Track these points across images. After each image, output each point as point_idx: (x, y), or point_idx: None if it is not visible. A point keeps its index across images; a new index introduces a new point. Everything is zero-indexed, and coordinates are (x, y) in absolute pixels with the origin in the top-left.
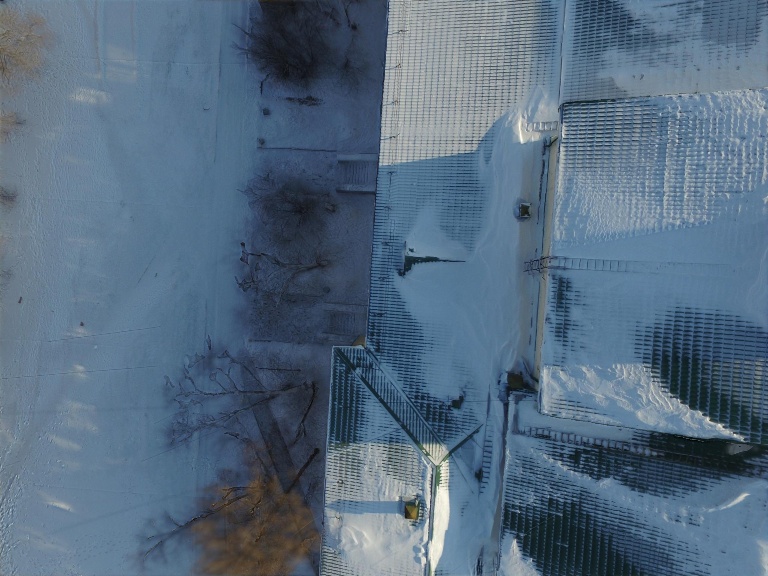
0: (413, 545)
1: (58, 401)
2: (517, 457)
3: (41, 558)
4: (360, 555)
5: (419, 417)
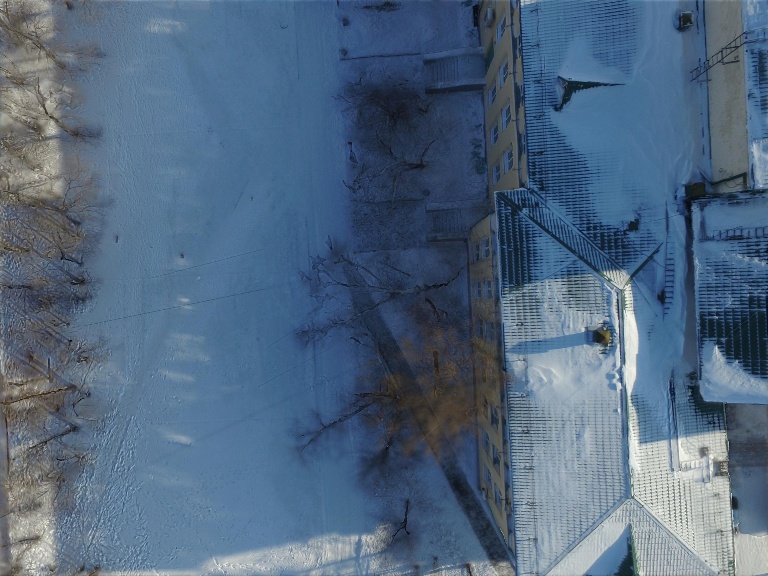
0: (606, 373)
1: (166, 337)
2: (708, 264)
3: (167, 496)
4: (550, 393)
5: (594, 247)
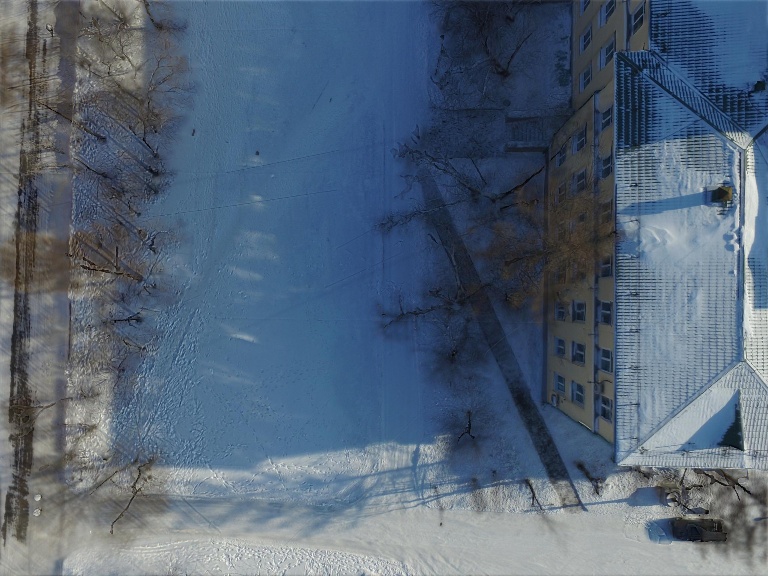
0: (723, 233)
1: (236, 233)
2: None
3: (226, 392)
4: (663, 254)
5: (716, 109)
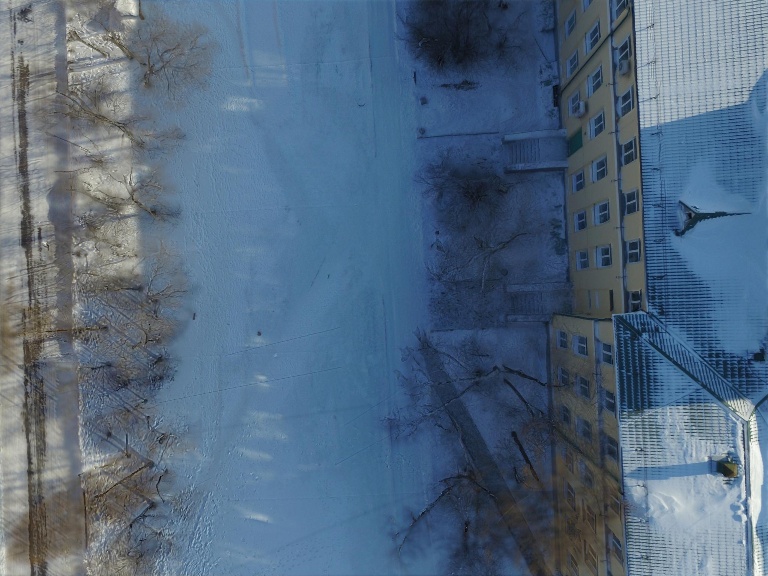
0: (730, 504)
1: (243, 414)
2: None
3: (244, 573)
4: (671, 520)
5: (716, 375)
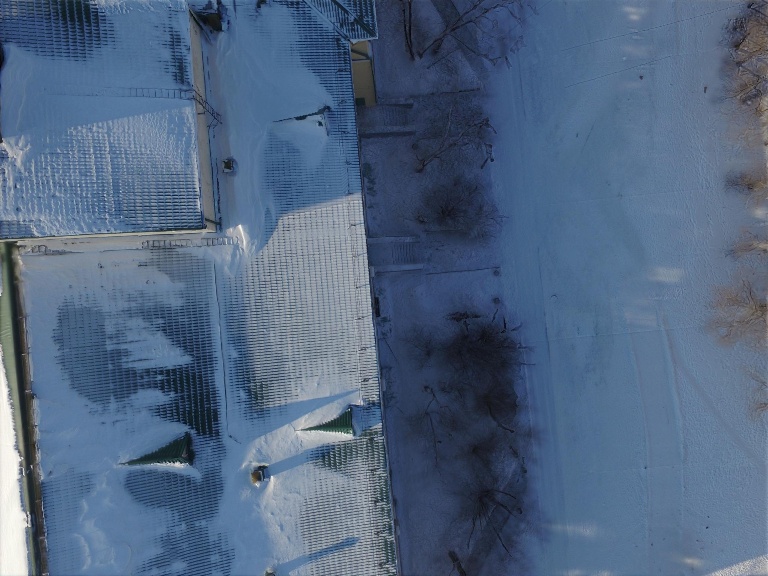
0: None
1: (653, 2)
2: None
3: None
4: None
5: None
